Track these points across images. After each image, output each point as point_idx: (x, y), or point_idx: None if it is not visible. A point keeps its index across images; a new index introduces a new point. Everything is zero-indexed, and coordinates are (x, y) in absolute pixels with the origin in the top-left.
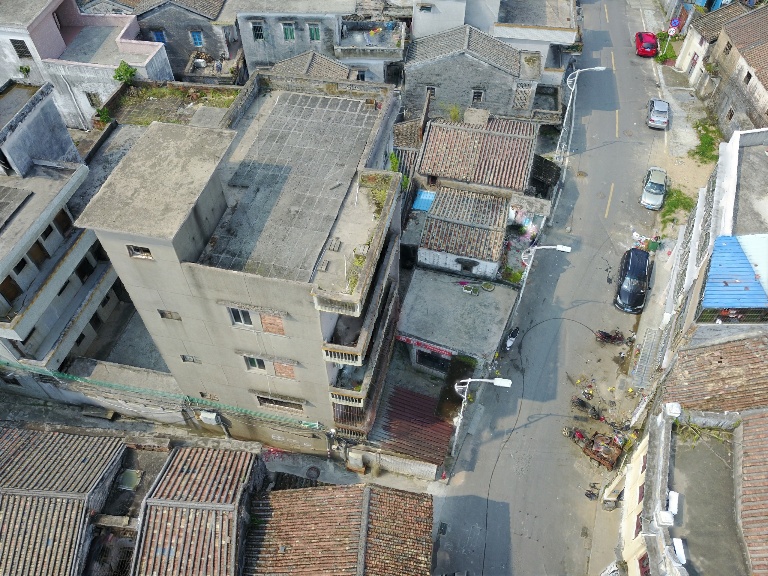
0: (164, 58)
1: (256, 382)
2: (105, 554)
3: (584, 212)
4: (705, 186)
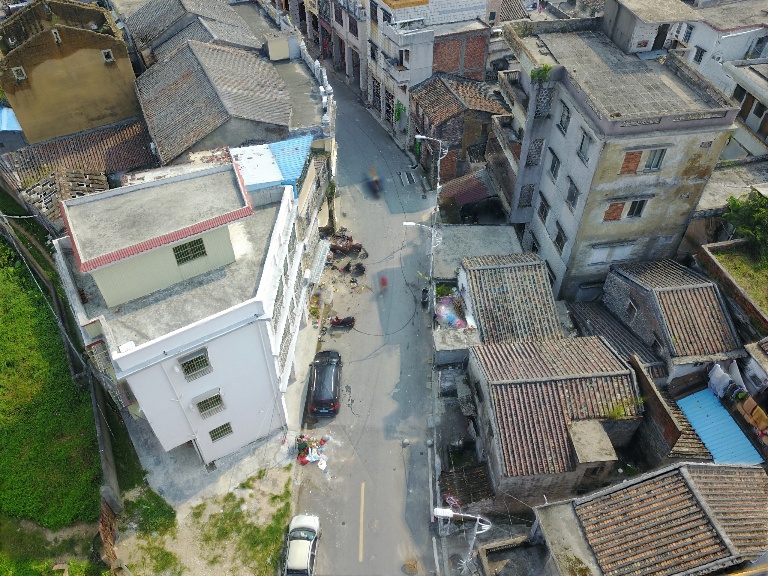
0: None
1: None
2: None
3: (392, 483)
4: None
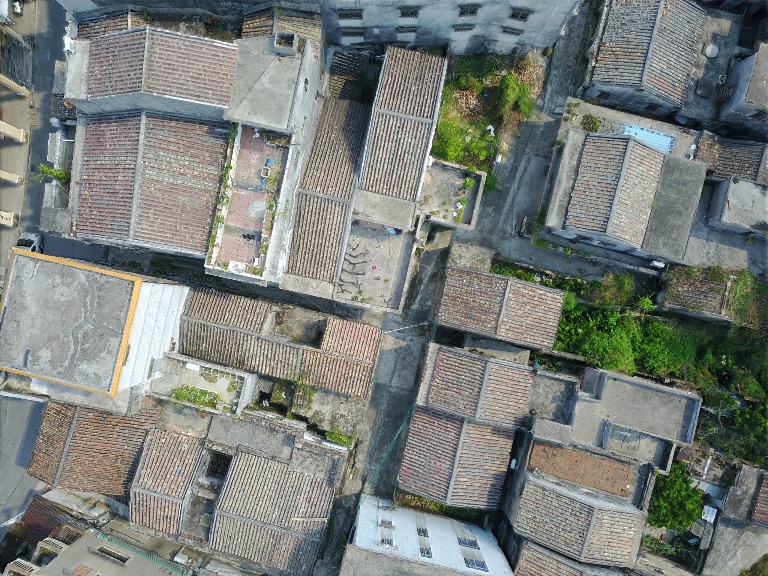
0: None
1: (114, 570)
2: (219, 478)
3: None
4: None
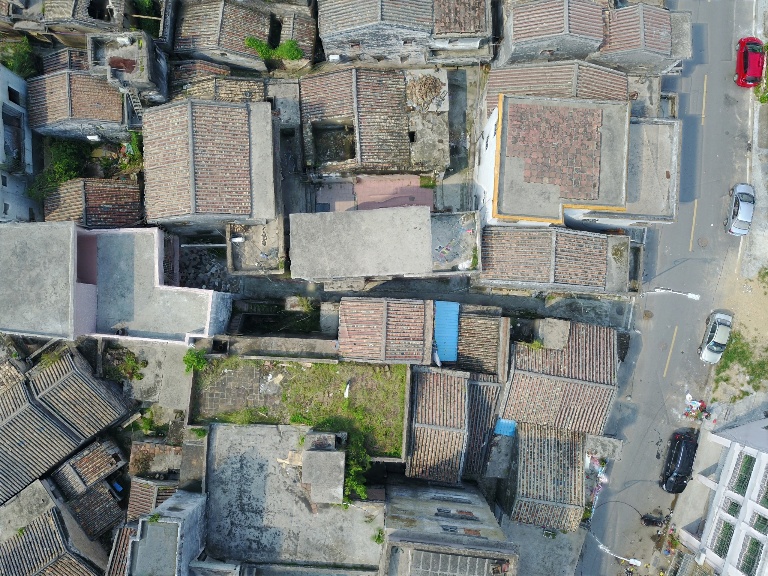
0: (215, 297)
1: None
2: None
3: (645, 371)
4: (764, 452)
